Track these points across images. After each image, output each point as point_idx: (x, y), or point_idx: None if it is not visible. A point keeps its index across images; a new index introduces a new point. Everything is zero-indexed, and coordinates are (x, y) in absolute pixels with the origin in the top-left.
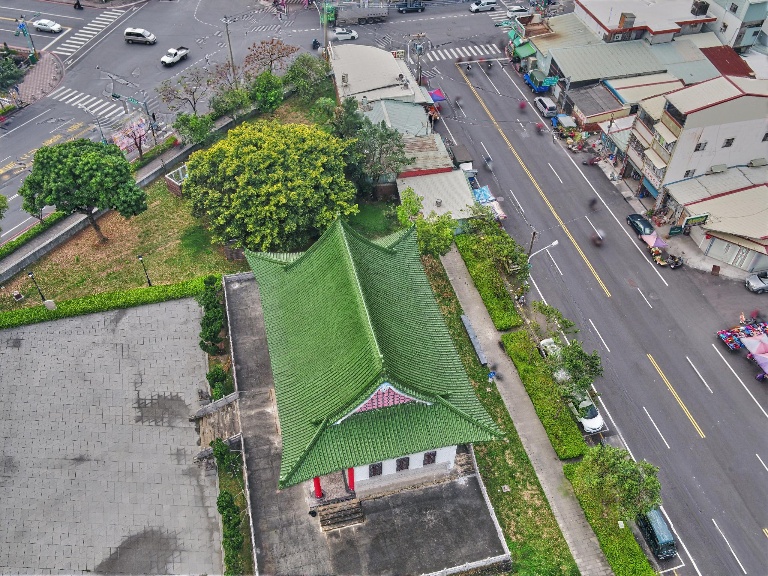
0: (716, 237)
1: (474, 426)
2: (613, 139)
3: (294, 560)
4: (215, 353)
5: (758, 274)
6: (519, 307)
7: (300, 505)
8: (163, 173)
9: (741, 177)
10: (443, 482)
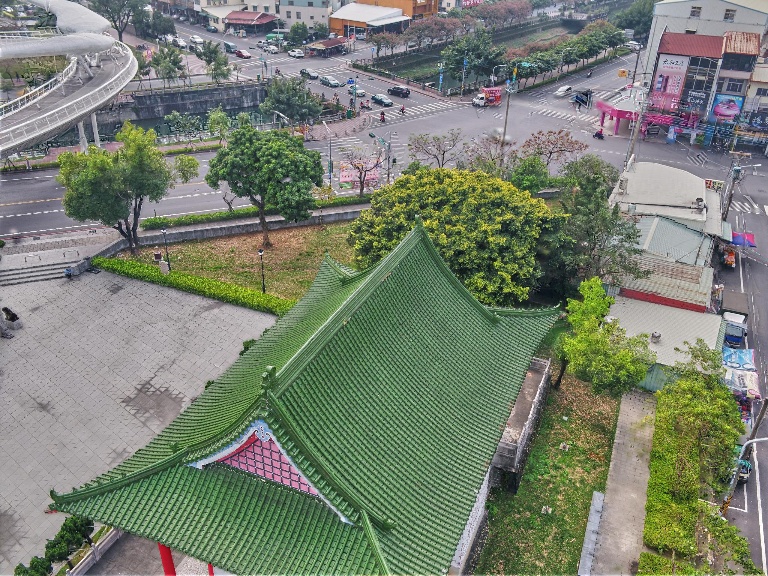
0: None
1: None
2: None
3: None
4: None
5: None
6: None
7: None
8: None
9: None
10: None
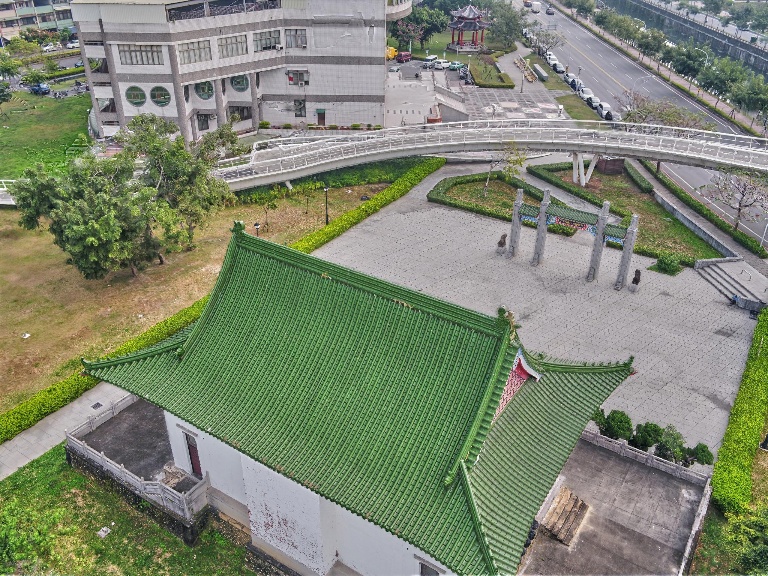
0: None
1: None
2: None
3: None
4: None
5: None
6: None
7: None
8: None
9: None
10: None
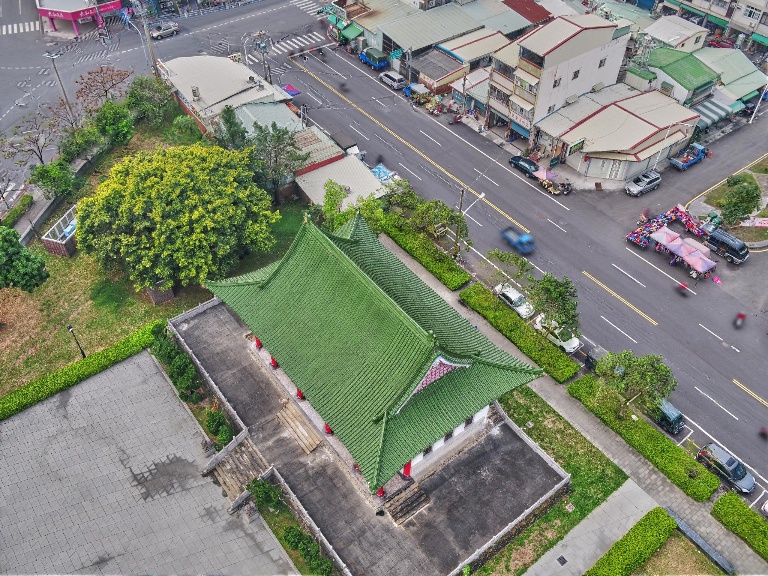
0: (594, 157)
1: (513, 372)
2: (471, 95)
3: (386, 563)
4: (198, 400)
5: (633, 180)
6: (459, 265)
7: (364, 511)
8: (32, 237)
9: (591, 102)
10: (480, 438)
